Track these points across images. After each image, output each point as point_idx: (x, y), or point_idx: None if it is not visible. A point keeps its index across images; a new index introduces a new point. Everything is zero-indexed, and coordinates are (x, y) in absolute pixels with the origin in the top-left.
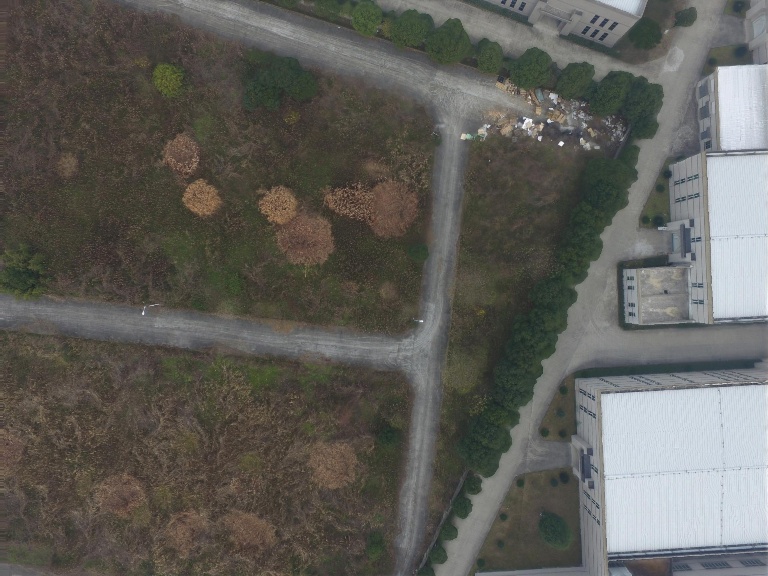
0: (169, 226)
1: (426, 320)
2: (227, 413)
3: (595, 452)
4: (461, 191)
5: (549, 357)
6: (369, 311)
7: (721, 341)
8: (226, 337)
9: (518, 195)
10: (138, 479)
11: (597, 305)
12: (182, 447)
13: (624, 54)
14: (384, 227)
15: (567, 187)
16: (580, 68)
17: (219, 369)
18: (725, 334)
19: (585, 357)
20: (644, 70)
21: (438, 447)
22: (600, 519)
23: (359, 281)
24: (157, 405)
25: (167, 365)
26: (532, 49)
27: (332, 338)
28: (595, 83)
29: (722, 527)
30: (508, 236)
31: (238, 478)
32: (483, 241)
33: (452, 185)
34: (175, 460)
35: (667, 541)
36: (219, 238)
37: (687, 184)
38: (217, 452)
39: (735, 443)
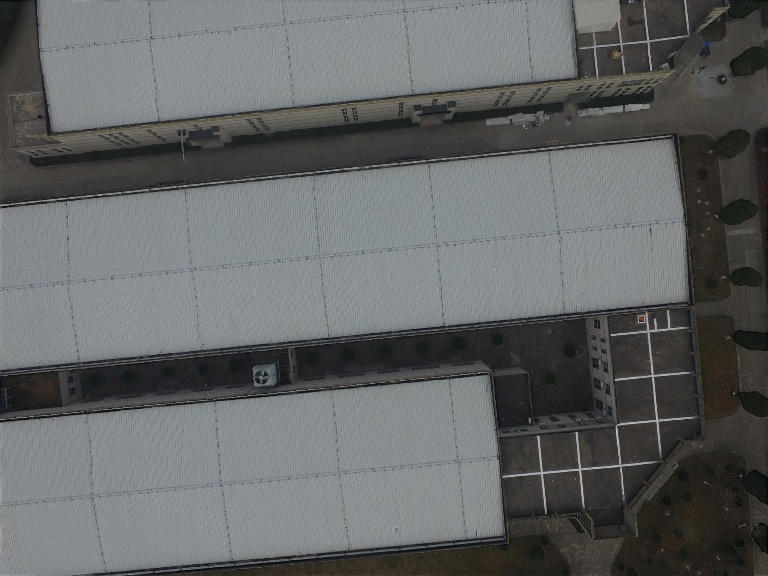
0: None
1: None
2: None
3: None
4: None
5: None
6: None
7: (134, 172)
8: None
9: None
10: None
11: (8, 143)
12: None
13: None
14: None
15: None
16: None
17: None
18: (138, 165)
19: None
20: None
21: None
22: None
23: None
24: None
25: None
26: None
27: None
28: None
29: (77, 343)
30: None
31: None
32: None
33: None
34: None
35: (24, 359)
36: None
37: None
38: None
39: (81, 256)
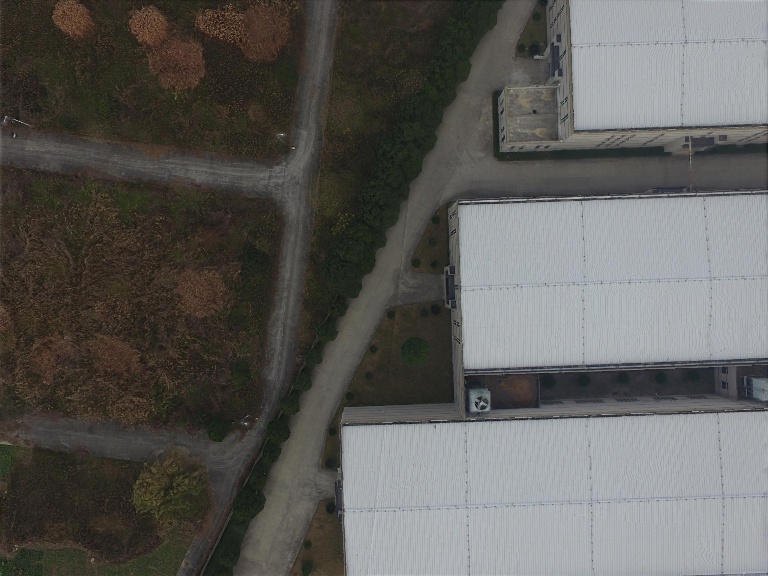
0: (40, 45)
1: (298, 147)
2: (93, 234)
3: (456, 269)
4: (335, 17)
5: (422, 187)
6: (237, 133)
7: (599, 174)
8: (96, 161)
9: (392, 22)
10: (4, 302)
11: (472, 135)
12: (48, 270)
13: None
14: (256, 51)
15: (442, 15)
16: None
17: (89, 193)
18: (603, 167)
19: (459, 188)
20: None
21: (308, 276)
22: (459, 336)
23: (229, 104)
24: (24, 226)
25: (37, 189)
26: None
27: (203, 164)
28: None
29: (584, 345)
30: (379, 60)
31: (104, 302)
32: (355, 66)
33: (326, 11)
34: (42, 284)
35: (527, 358)
36: (89, 59)
37: (556, 2)
38: (82, 274)
39: (597, 257)
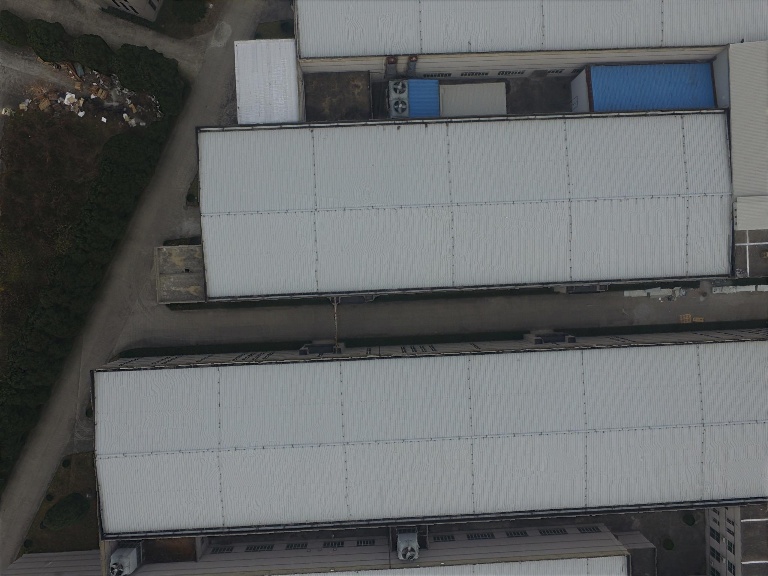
0: None
1: None
2: None
3: None
4: (3, 167)
5: (94, 336)
6: None
7: (272, 322)
8: None
9: (59, 171)
10: None
11: (144, 284)
12: None
13: (168, 28)
14: None
15: None
16: (75, 40)
17: None
18: (276, 315)
19: (132, 337)
20: (190, 45)
21: None
22: None
23: None
24: None
25: None
26: (32, 20)
27: None
28: (111, 57)
29: (223, 508)
30: (42, 213)
31: None
32: None
33: None
34: None
35: (167, 522)
36: None
37: None
38: None
39: (232, 423)
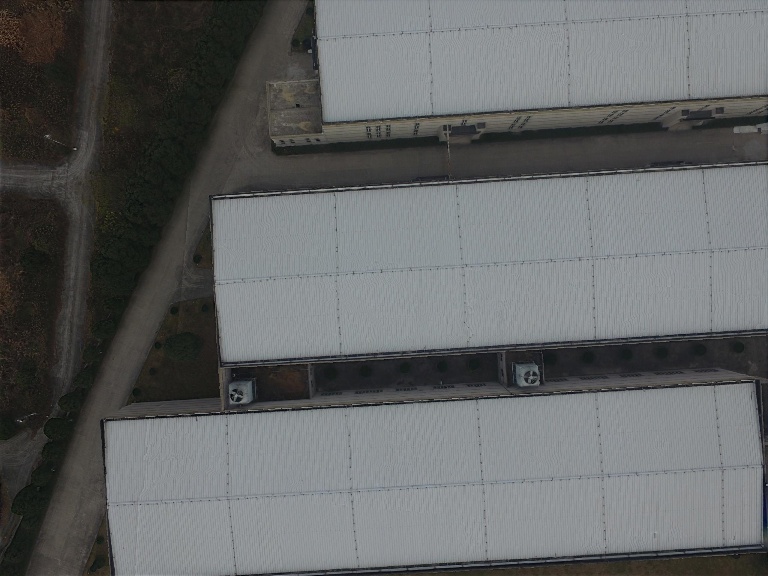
0: None
1: (79, 148)
2: None
3: None
4: (112, 19)
5: (202, 183)
6: (16, 136)
7: (377, 165)
8: None
9: (167, 21)
10: None
11: (250, 130)
12: None
13: None
14: (35, 55)
15: None
16: None
17: None
18: (381, 158)
19: (239, 183)
20: None
21: None
22: None
23: (8, 107)
24: None
25: None
26: None
27: None
28: None
29: (341, 335)
30: (152, 59)
31: None
32: None
33: (103, 13)
34: None
35: (285, 350)
36: None
37: None
38: None
39: (349, 247)
